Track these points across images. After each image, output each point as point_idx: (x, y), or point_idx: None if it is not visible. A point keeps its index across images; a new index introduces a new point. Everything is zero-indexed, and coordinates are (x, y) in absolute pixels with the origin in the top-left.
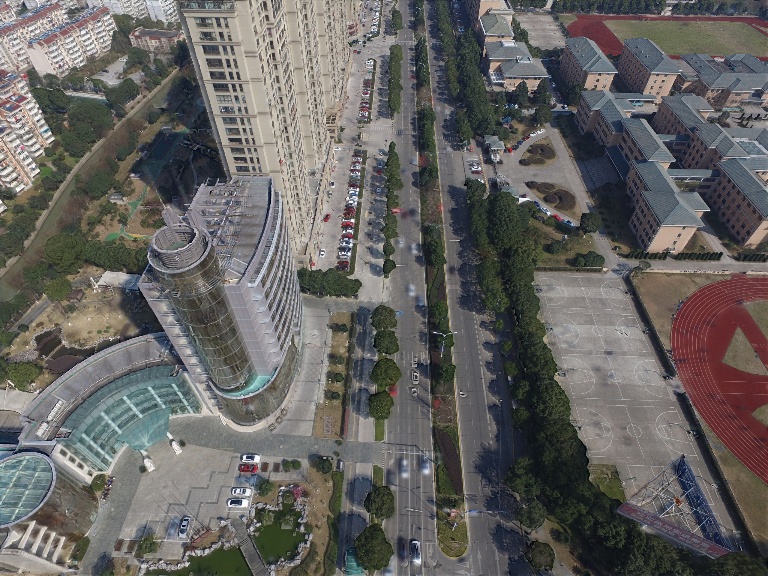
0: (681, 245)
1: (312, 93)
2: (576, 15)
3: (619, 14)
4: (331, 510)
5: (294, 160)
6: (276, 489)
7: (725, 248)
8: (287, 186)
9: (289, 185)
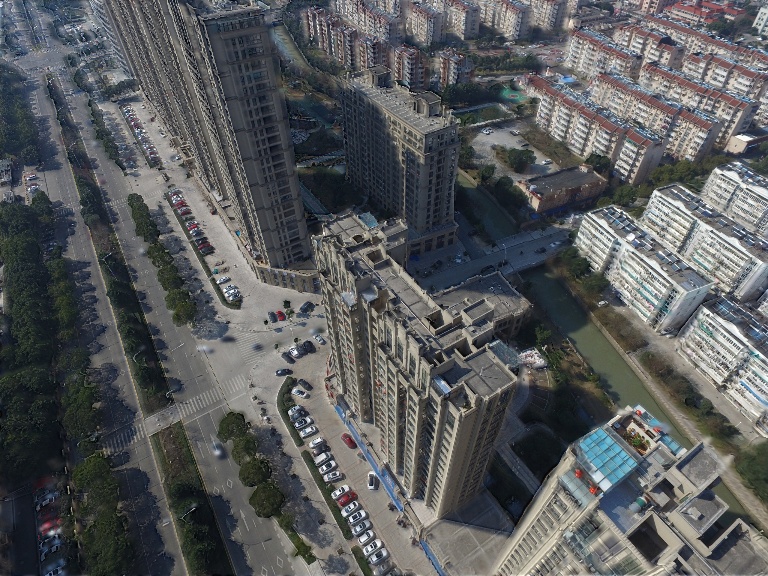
0: None
1: None
2: None
3: None
4: None
5: None
6: None
7: None
8: None
9: None
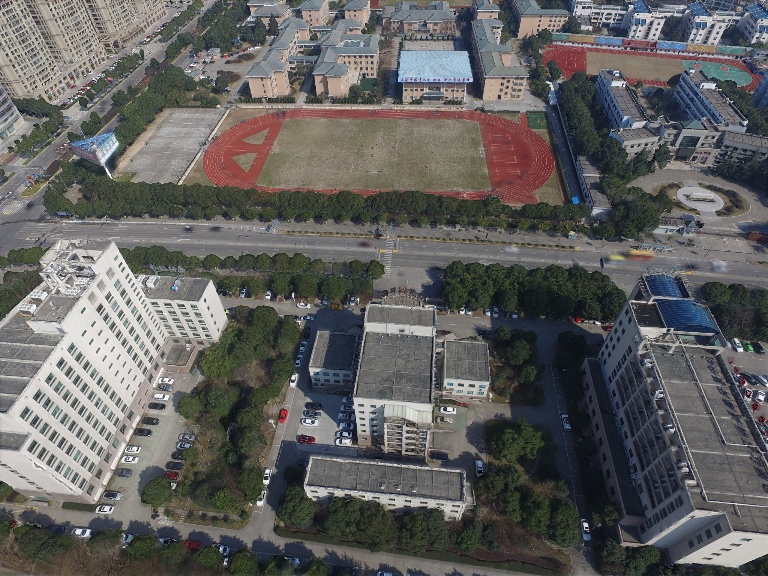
0: (270, 93)
1: (59, 7)
2: None
3: None
4: None
5: (9, 30)
6: None
7: None
8: (4, 44)
9: (7, 44)
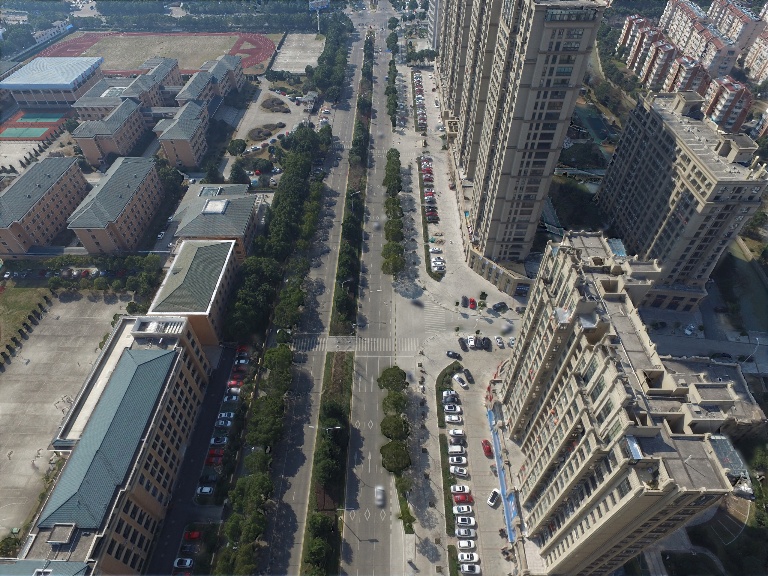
0: None
1: None
2: None
3: None
4: (407, 33)
5: None
6: (425, 35)
7: None
8: None
9: None
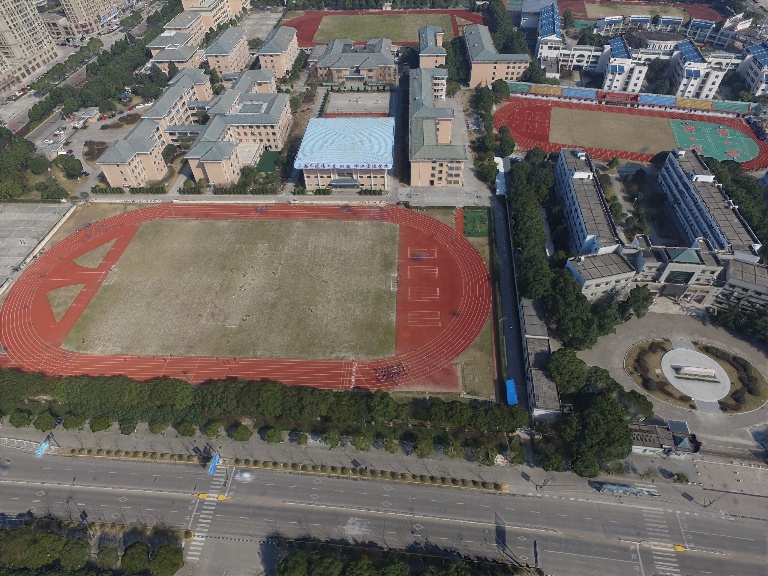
0: (132, 181)
1: None
2: (307, 12)
3: (346, 10)
4: None
5: None
6: None
7: (183, 185)
8: None
9: None
